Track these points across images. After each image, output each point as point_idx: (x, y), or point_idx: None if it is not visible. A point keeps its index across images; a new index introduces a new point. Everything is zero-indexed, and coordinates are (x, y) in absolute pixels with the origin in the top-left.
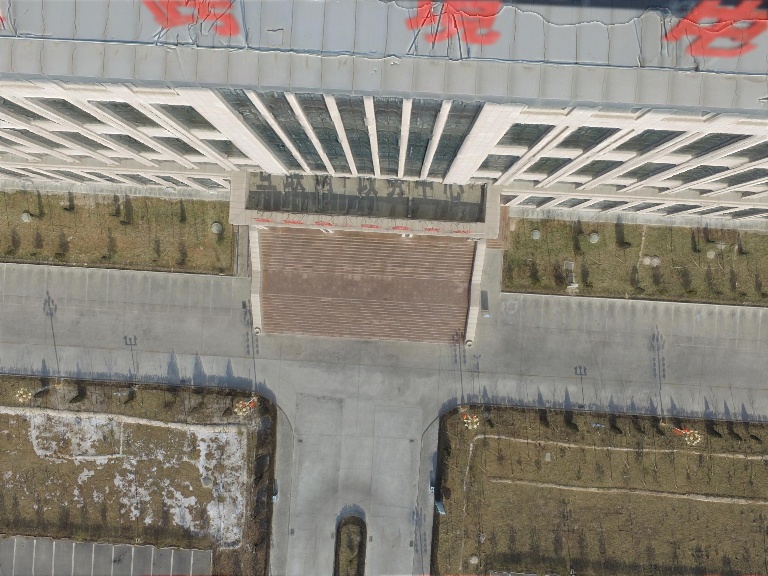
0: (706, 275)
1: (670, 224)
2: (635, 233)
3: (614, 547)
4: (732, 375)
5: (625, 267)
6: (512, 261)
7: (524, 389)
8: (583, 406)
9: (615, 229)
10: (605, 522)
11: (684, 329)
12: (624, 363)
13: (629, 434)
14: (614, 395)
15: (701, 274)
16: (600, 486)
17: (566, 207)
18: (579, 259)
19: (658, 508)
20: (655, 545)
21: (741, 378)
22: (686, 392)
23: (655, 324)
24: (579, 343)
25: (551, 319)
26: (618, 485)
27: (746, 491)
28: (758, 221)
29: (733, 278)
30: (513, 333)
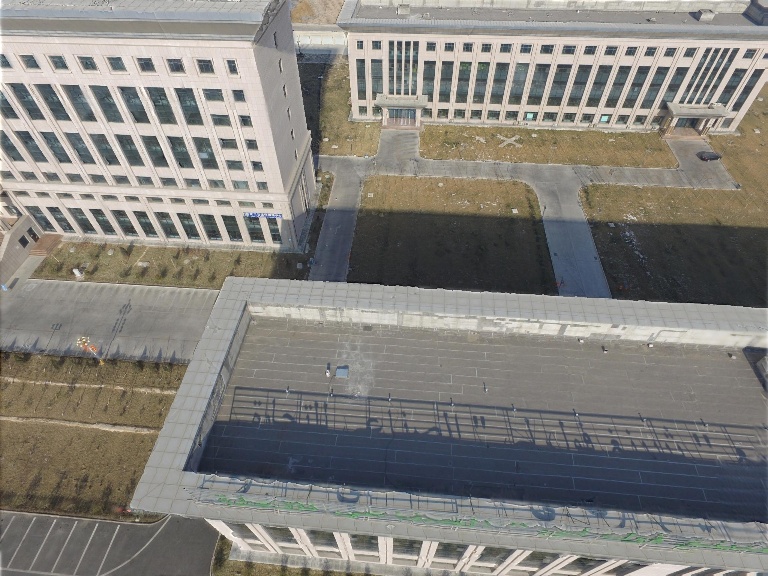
0: (179, 272)
1: (164, 245)
2: (141, 250)
3: (2, 476)
4: (173, 331)
5: (124, 267)
6: (48, 263)
7: (4, 338)
8: (44, 351)
9: (128, 248)
10: (8, 450)
11: (149, 302)
12: (93, 322)
13: (70, 372)
14: (73, 343)
15: (175, 271)
16: (22, 416)
17: (97, 234)
18: (95, 262)
19: (65, 438)
20: (44, 475)
21: (180, 333)
22: (132, 342)
23: (129, 298)
24: (66, 309)
25: (54, 295)
26: (39, 415)
27: (153, 422)
28: (222, 244)
29: (196, 273)
30: (21, 302)
